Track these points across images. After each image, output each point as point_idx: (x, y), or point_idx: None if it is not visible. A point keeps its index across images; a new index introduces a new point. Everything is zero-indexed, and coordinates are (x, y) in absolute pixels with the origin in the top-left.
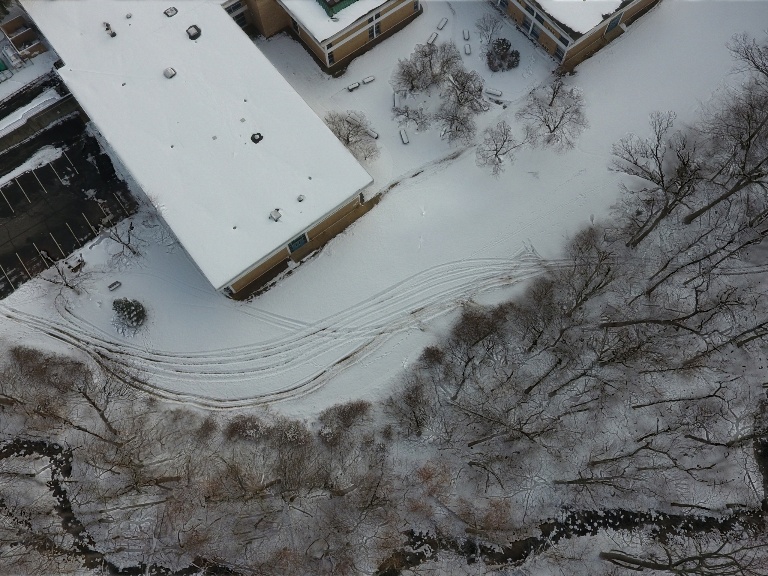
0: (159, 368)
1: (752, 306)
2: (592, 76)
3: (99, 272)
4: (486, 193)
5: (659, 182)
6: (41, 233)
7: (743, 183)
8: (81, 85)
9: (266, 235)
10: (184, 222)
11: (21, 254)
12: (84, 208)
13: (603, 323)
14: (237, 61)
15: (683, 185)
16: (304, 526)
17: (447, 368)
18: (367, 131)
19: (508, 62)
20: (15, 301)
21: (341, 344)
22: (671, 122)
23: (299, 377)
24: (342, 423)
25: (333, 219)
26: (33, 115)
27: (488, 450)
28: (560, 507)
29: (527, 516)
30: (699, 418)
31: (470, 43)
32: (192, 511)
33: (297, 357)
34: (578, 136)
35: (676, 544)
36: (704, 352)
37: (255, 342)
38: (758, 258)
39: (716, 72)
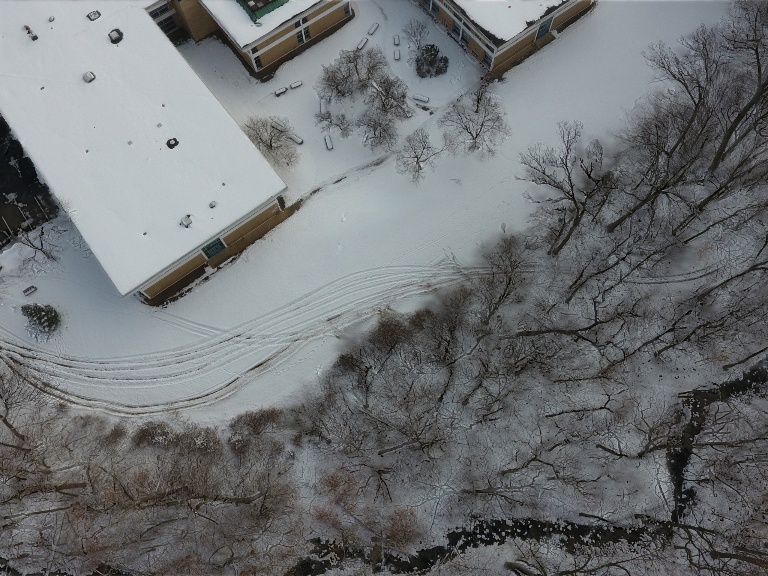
0: (71, 374)
1: (671, 315)
2: (520, 83)
3: (15, 276)
4: (407, 200)
5: (568, 191)
6: None
7: (653, 193)
8: None
9: (176, 241)
10: (94, 228)
11: None
12: (4, 212)
13: (519, 331)
14: (157, 66)
15: (588, 195)
16: (209, 533)
17: (361, 376)
18: (289, 137)
19: (436, 68)
20: None
21: (255, 351)
22: (578, 132)
23: (211, 384)
24: (252, 430)
25: (251, 225)
26: None
27: (398, 458)
28: (469, 516)
29: (435, 525)
30: (611, 428)
31: (400, 48)
32: (95, 518)
33: (210, 363)
34: (501, 143)
35: (583, 554)
36: (621, 361)
37: (168, 348)
38: (680, 267)
39: (646, 80)
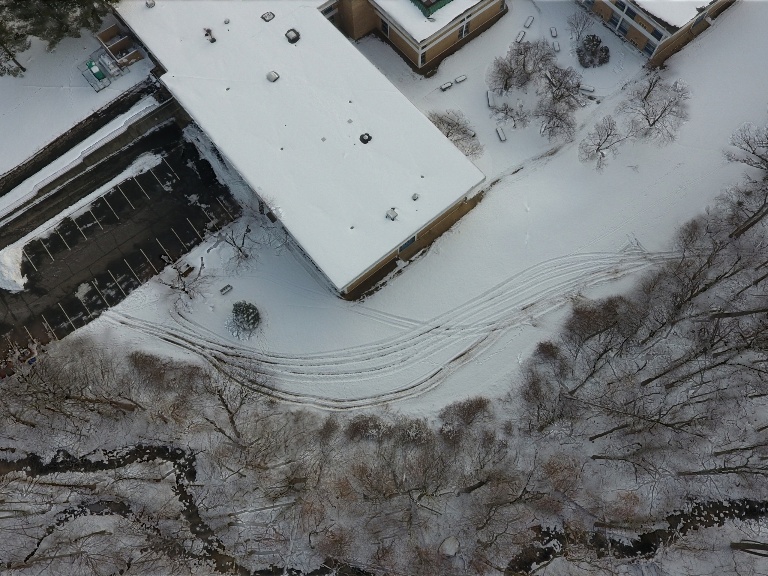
0: (276, 370)
1: None
2: (682, 70)
3: (209, 276)
4: (588, 188)
5: None
6: (147, 239)
7: None
8: (186, 91)
9: (384, 234)
10: (301, 223)
11: (129, 260)
12: (188, 213)
13: (714, 314)
14: (338, 63)
15: None
16: (433, 524)
17: (562, 363)
18: (467, 129)
19: (599, 58)
20: (128, 307)
21: (455, 342)
22: None
23: (416, 375)
24: (462, 420)
25: (440, 217)
26: (134, 122)
27: (610, 443)
28: (685, 499)
29: (653, 508)
30: None
31: (558, 40)
32: (323, 512)
33: (413, 356)
34: None
35: None
36: None
37: (370, 342)
38: None
39: None
